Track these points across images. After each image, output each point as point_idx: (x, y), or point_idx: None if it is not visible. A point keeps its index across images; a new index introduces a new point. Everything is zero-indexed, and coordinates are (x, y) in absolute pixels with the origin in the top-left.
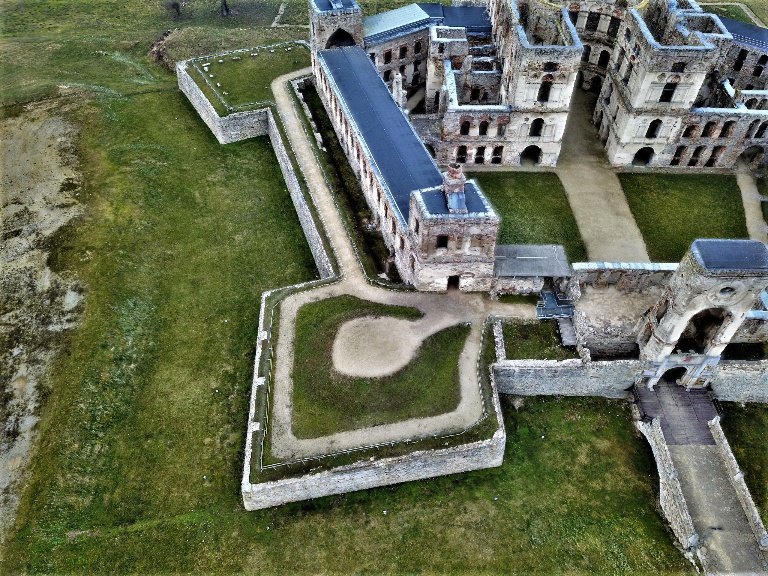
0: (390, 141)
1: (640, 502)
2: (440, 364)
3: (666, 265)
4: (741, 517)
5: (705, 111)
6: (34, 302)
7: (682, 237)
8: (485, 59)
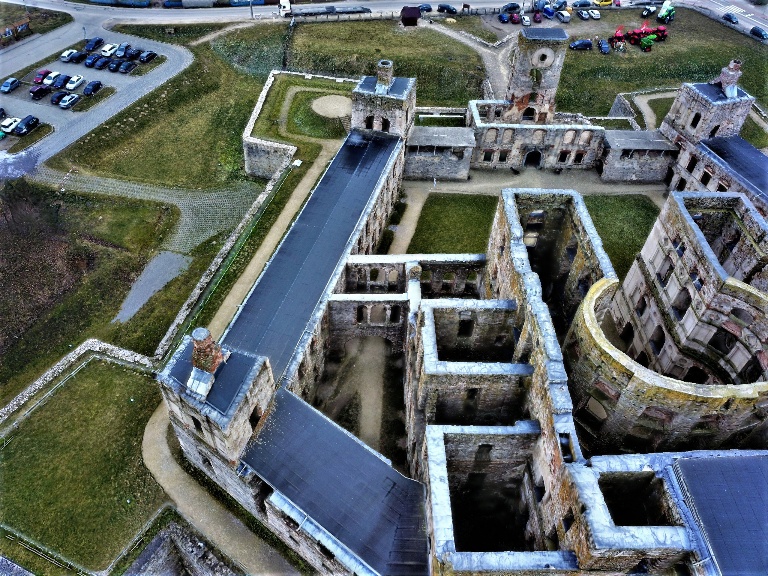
0: None
1: None
2: (667, 112)
3: (538, 127)
4: (494, 89)
5: (467, 254)
6: None
7: (482, 220)
8: None
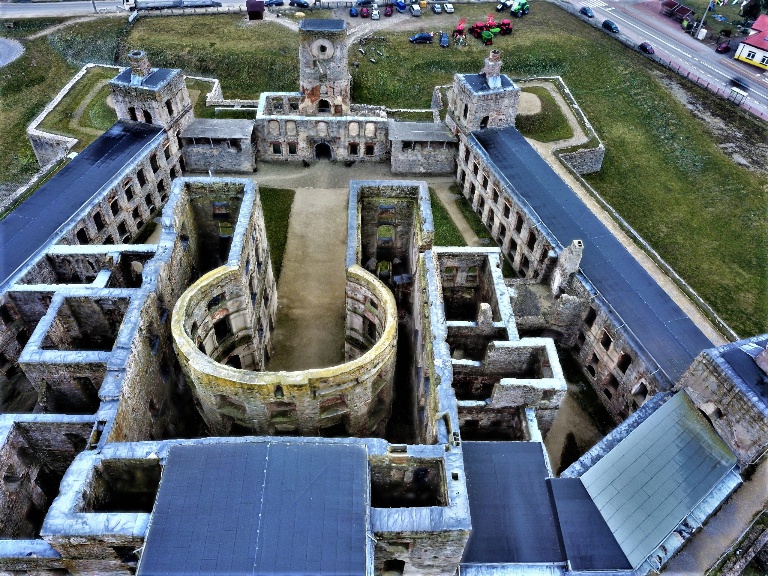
0: (556, 197)
1: (360, 103)
2: None
3: (319, 118)
4: None
5: None
6: (764, 158)
7: None
8: (454, 360)
